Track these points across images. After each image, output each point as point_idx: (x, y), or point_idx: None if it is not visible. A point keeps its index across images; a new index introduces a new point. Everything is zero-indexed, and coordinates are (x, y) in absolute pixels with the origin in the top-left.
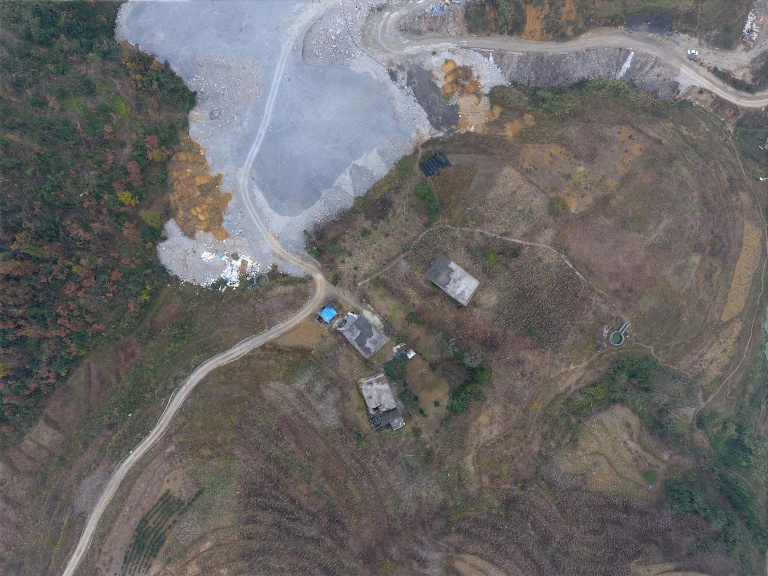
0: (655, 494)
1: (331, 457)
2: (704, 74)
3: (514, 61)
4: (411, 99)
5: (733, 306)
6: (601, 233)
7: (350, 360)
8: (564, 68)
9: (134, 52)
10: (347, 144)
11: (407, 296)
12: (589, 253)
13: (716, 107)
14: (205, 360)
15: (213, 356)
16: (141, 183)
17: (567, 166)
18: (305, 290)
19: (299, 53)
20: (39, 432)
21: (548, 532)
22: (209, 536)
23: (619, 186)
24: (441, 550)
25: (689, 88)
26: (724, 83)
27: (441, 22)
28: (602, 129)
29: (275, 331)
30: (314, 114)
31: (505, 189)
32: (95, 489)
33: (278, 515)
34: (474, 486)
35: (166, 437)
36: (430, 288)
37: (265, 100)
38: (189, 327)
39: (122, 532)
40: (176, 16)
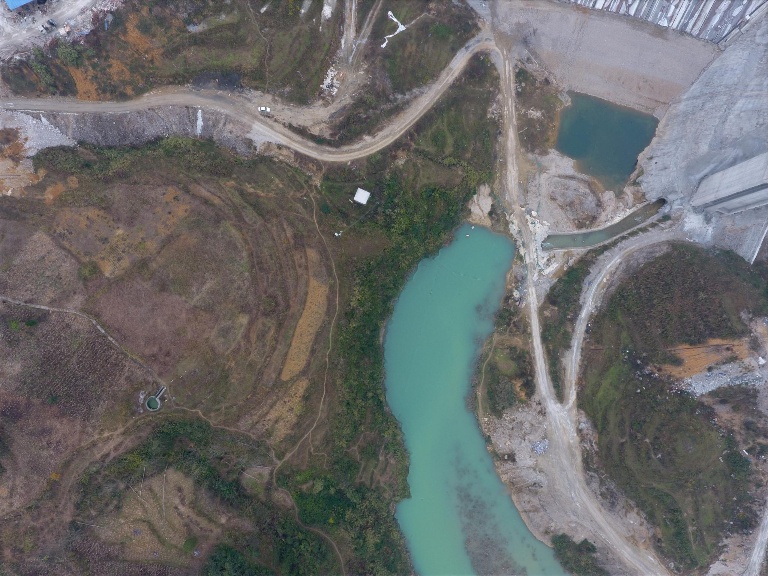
0: (198, 561)
1: None
2: (280, 130)
3: (71, 121)
4: None
5: (294, 365)
6: (137, 297)
7: None
8: (130, 127)
9: None
10: None
11: None
12: (123, 318)
13: (299, 162)
14: None
15: None
16: None
17: (105, 229)
18: None
19: None
20: None
21: None
22: None
23: (159, 248)
24: None
25: (266, 144)
26: (303, 138)
27: None
28: (145, 191)
29: None
30: None
31: (33, 255)
32: None
33: None
34: None
35: None
36: None
37: None
38: None
39: None
40: None
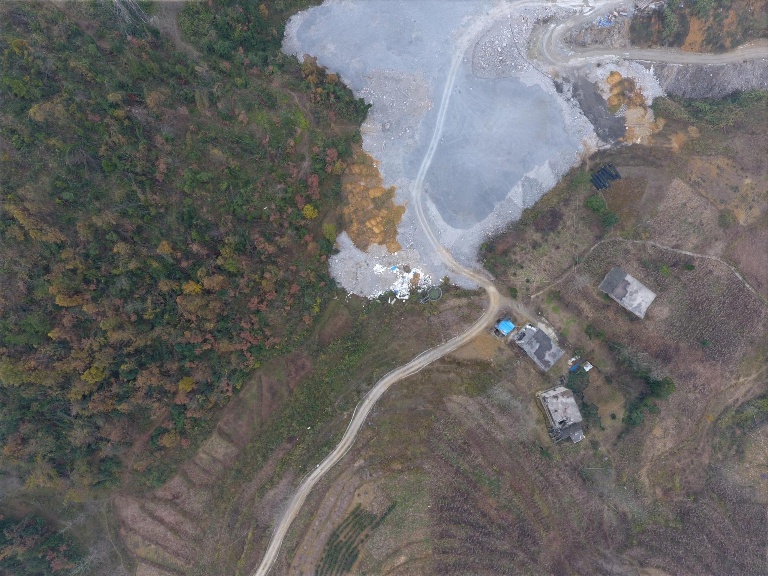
0: None
1: (517, 471)
2: None
3: (673, 72)
4: (577, 111)
5: None
6: None
7: (528, 373)
8: (720, 79)
9: (314, 65)
10: (521, 157)
11: (580, 309)
12: (758, 265)
13: None
14: (386, 373)
15: (393, 369)
16: (319, 196)
17: (734, 178)
18: (479, 303)
19: (469, 65)
20: (213, 445)
21: (724, 545)
22: (403, 550)
23: None
24: (625, 563)
25: None
26: None
27: (606, 34)
28: (767, 141)
29: (452, 344)
30: (485, 126)
31: (675, 201)
32: (279, 503)
33: (471, 529)
34: (649, 499)
35: (354, 451)
36: (603, 300)
37: (436, 112)
38: (360, 340)
39: (312, 546)
40: (346, 28)
